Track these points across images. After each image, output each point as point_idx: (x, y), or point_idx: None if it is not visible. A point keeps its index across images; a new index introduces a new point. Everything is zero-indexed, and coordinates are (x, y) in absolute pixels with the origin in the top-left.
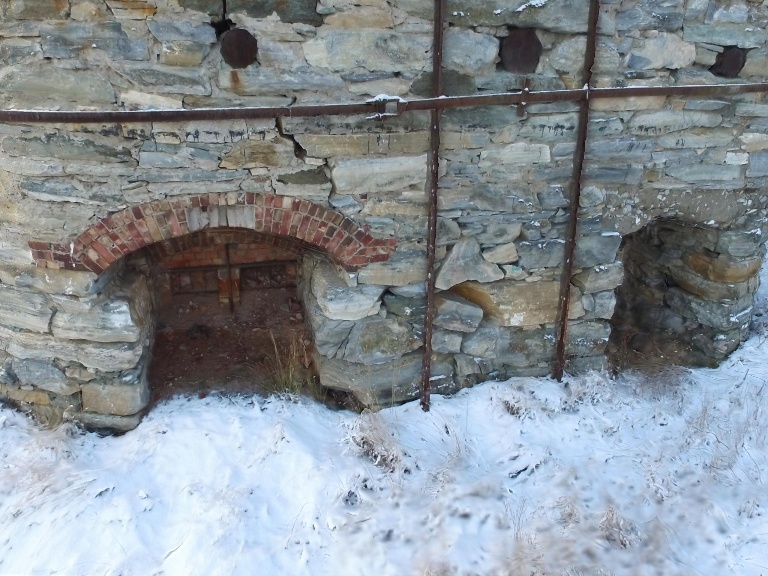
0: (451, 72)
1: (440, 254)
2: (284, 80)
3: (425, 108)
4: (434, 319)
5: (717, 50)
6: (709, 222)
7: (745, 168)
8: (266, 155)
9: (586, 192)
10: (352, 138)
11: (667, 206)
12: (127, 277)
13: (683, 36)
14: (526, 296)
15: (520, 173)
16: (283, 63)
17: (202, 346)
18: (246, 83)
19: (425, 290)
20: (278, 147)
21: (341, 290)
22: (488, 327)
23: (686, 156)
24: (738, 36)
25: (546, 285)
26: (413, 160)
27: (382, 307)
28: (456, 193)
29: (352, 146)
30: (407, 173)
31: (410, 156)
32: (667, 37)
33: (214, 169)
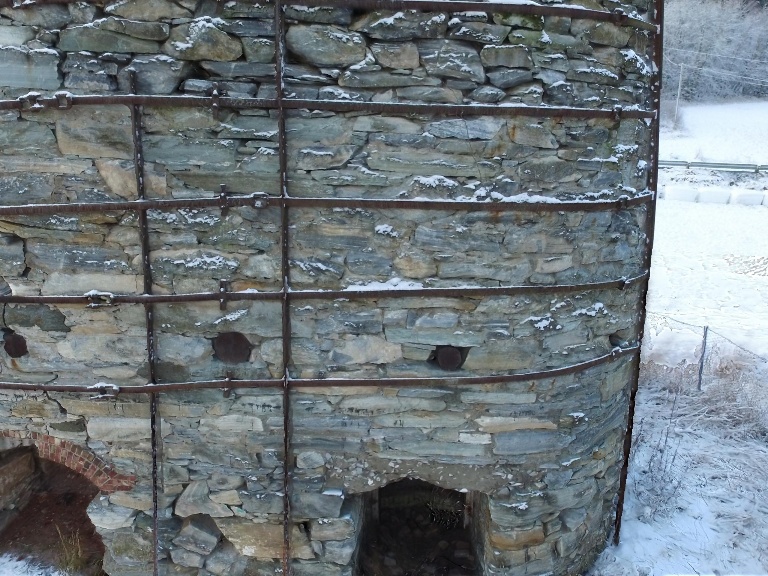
0: (167, 363)
1: (176, 490)
2: (44, 366)
3: (136, 392)
4: (174, 539)
5: (427, 348)
6: (461, 490)
7: (490, 447)
8: (39, 410)
9: (303, 456)
10: (96, 404)
11: (404, 472)
12: (9, 457)
13: (387, 337)
14: (254, 533)
15: (238, 437)
16: (44, 355)
17: (59, 512)
18: (21, 366)
19: (165, 515)
20: (47, 406)
21: (96, 507)
22: (224, 552)
23: (409, 434)
24: (448, 338)
25: (272, 527)
26: (144, 421)
27: (135, 522)
28: (182, 448)
29: (97, 409)
30: (140, 430)
31: (142, 418)
32: (369, 338)
33: (8, 416)
